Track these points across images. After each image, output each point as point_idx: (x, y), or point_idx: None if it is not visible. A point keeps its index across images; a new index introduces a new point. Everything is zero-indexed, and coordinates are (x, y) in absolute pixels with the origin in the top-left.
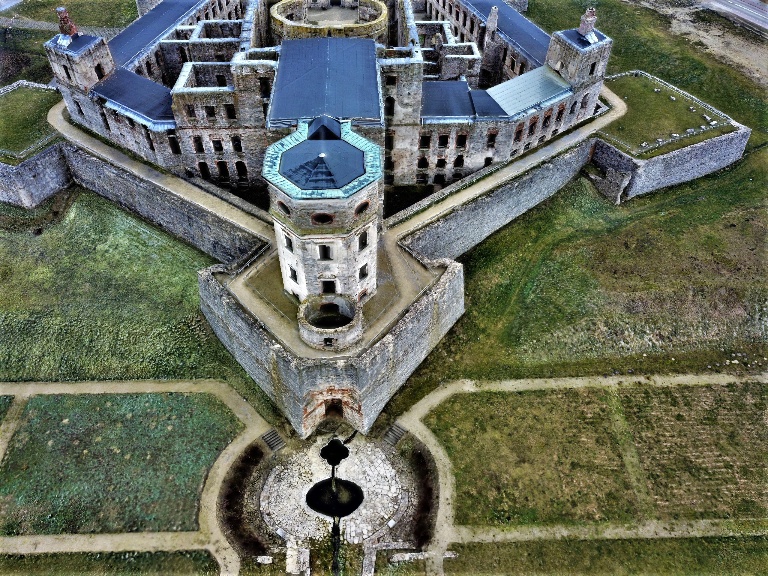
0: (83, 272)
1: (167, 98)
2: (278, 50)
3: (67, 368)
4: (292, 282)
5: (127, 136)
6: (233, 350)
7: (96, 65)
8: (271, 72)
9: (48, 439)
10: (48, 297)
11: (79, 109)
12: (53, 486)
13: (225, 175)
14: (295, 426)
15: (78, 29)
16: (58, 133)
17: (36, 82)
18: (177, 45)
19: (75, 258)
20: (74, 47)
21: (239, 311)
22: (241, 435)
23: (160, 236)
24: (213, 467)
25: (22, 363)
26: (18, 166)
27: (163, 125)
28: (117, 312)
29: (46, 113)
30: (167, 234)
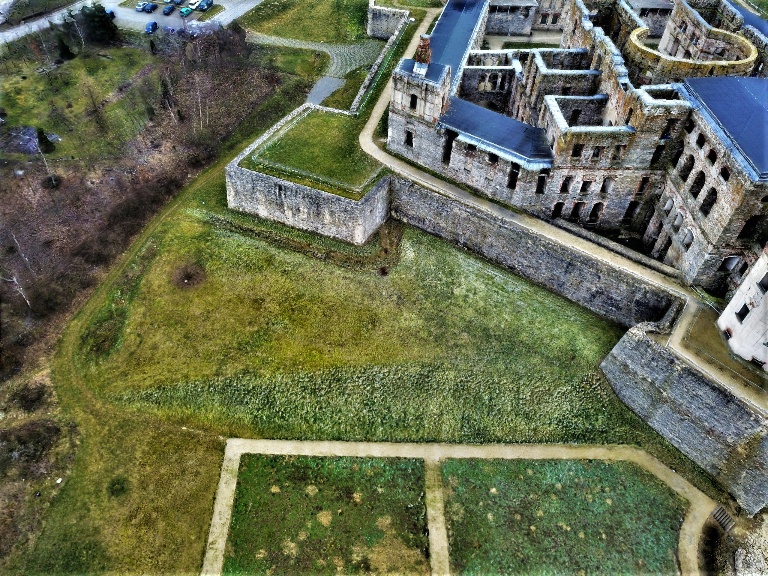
0: (454, 320)
1: (528, 133)
2: (676, 88)
3: (470, 429)
4: (764, 349)
5: (475, 172)
6: (650, 414)
7: (443, 95)
8: (685, 113)
9: (485, 512)
10: (431, 348)
11: (406, 139)
12: (519, 569)
13: (574, 216)
14: (745, 504)
15: (313, 45)
16: (382, 164)
17: (291, 102)
18: (481, 71)
19: (438, 303)
20: (432, 76)
21: (706, 379)
22: (690, 512)
23: (516, 281)
24: (680, 550)
25: (420, 422)
26: (362, 201)
27: (538, 164)
28: (511, 367)
29: (357, 141)
30: (522, 278)
